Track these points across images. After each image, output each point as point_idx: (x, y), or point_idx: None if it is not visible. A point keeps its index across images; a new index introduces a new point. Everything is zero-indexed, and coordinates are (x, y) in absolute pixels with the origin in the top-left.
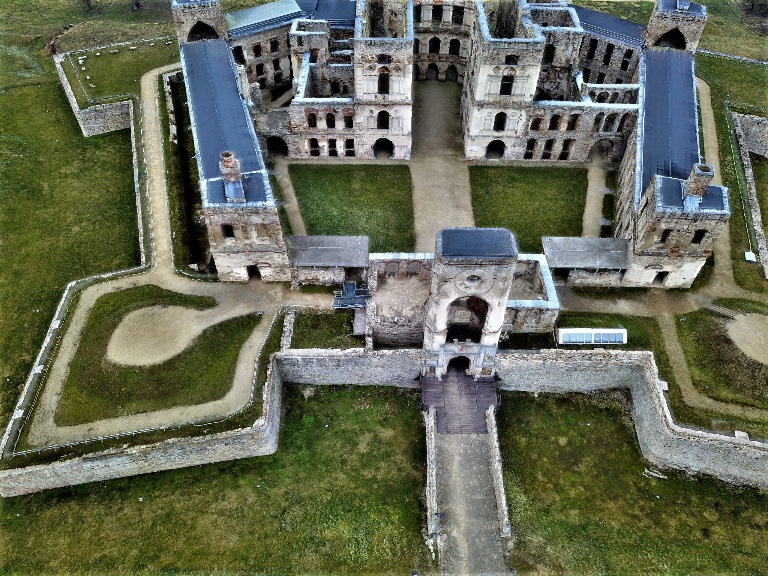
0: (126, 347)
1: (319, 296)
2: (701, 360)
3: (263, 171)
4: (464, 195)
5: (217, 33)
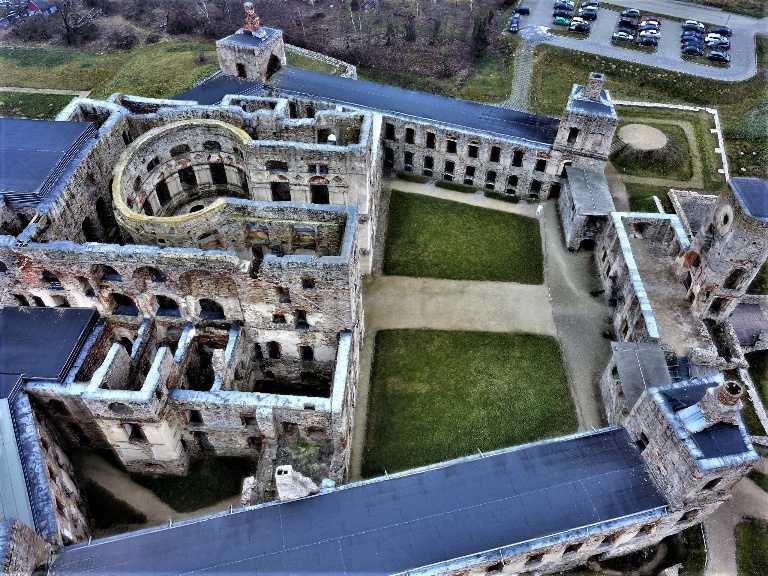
0: None
1: None
2: (660, 172)
3: (653, 390)
4: (441, 284)
5: (43, 564)
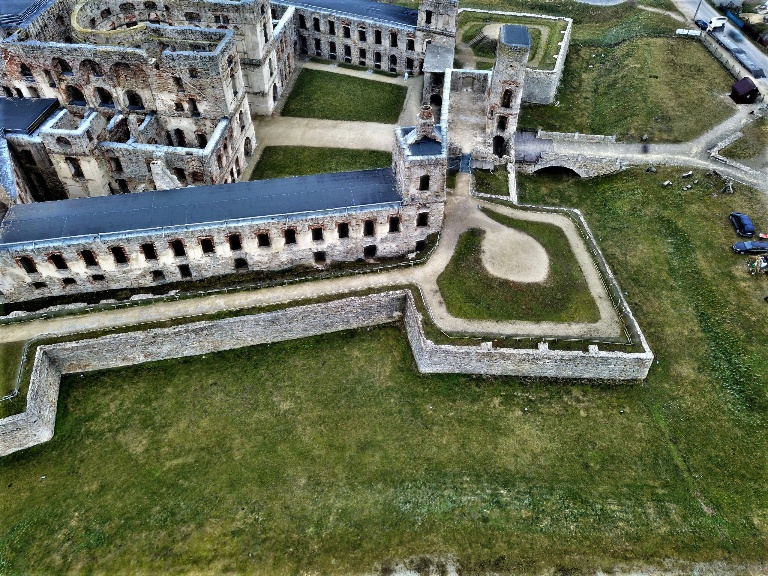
0: (530, 270)
1: (458, 179)
2: None
3: (398, 128)
4: (321, 122)
5: (4, 204)
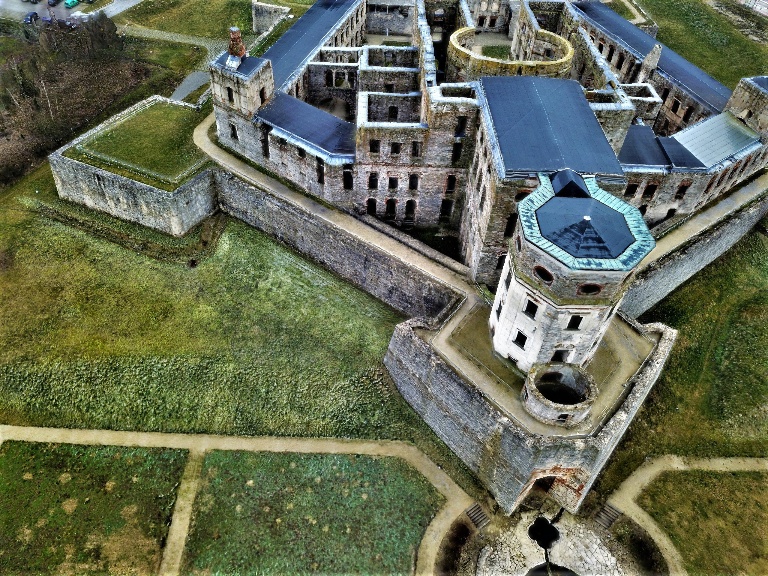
0: None
1: None
2: None
3: None
4: None
5: None
